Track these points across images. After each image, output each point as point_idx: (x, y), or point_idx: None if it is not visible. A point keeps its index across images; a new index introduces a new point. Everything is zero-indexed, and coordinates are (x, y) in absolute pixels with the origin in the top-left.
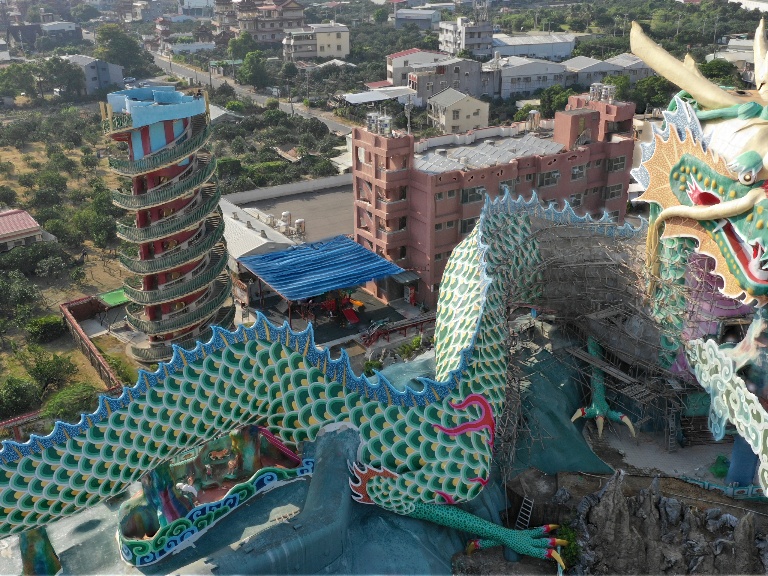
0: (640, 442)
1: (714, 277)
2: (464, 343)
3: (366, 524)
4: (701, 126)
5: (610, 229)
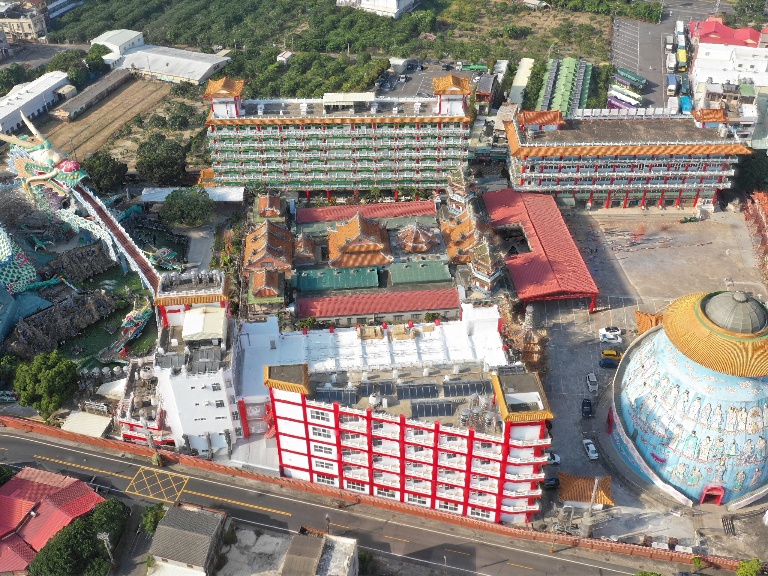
0: (57, 246)
1: (54, 192)
2: (4, 243)
3: (17, 298)
4: (29, 154)
5: (5, 188)
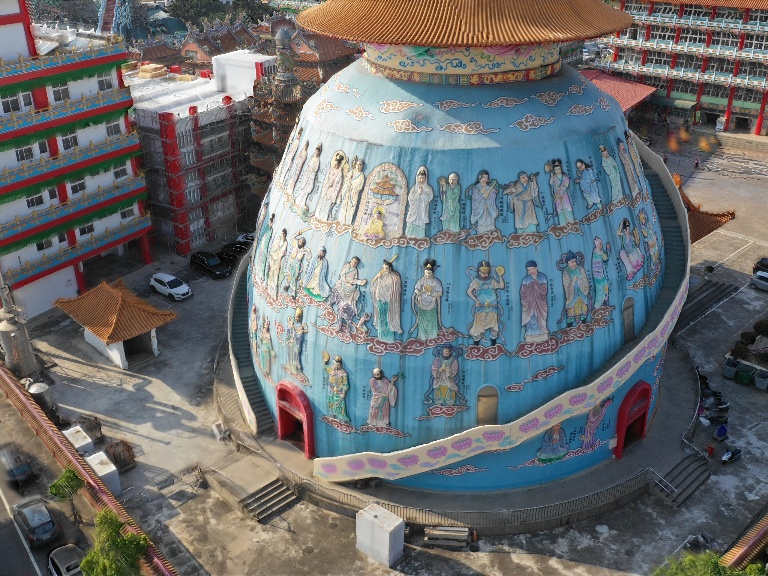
0: None
1: None
2: None
3: None
4: None
5: None
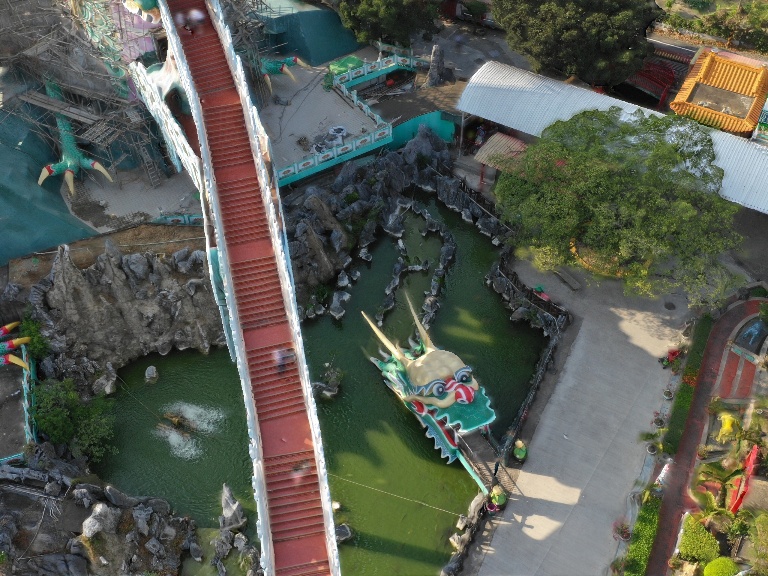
0: (124, 184)
1: None
2: None
3: None
4: None
5: None
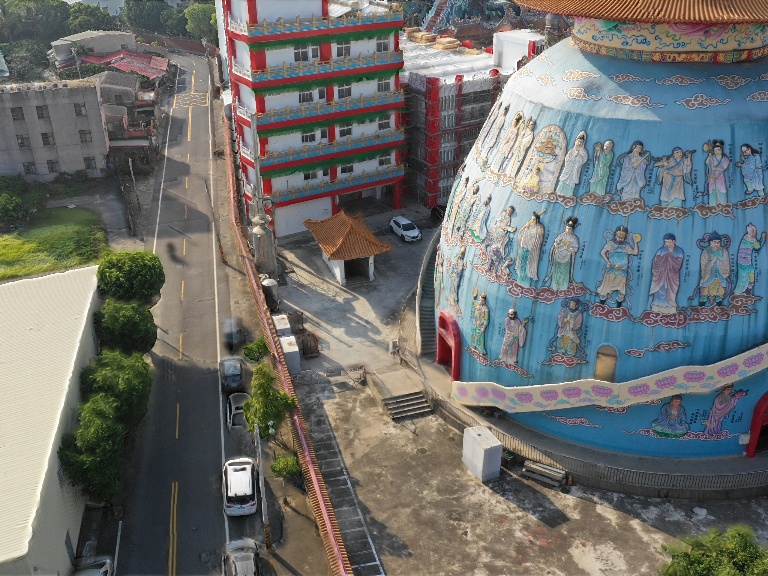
0: None
1: None
2: None
3: None
4: None
5: None
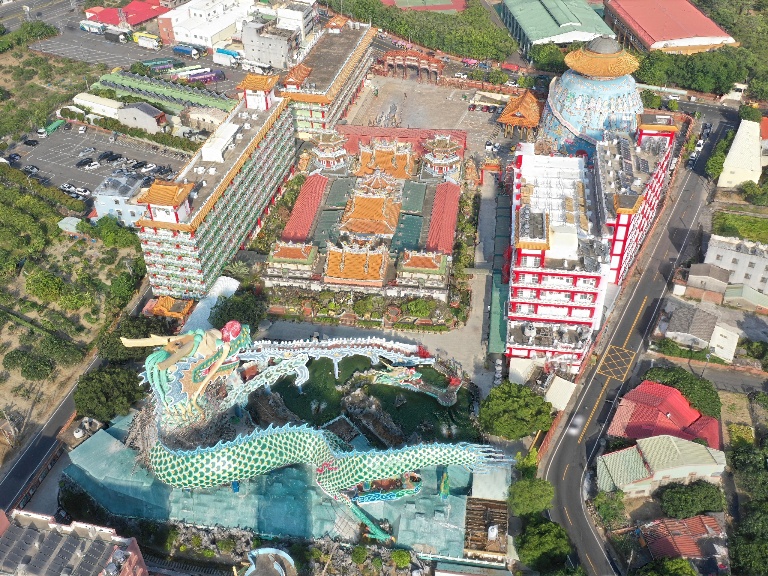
0: None
1: None
2: None
3: None
4: None
5: None
